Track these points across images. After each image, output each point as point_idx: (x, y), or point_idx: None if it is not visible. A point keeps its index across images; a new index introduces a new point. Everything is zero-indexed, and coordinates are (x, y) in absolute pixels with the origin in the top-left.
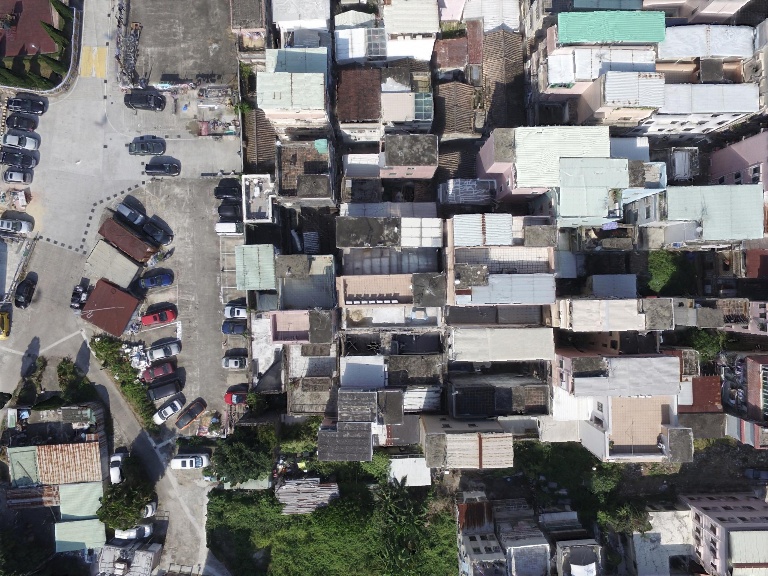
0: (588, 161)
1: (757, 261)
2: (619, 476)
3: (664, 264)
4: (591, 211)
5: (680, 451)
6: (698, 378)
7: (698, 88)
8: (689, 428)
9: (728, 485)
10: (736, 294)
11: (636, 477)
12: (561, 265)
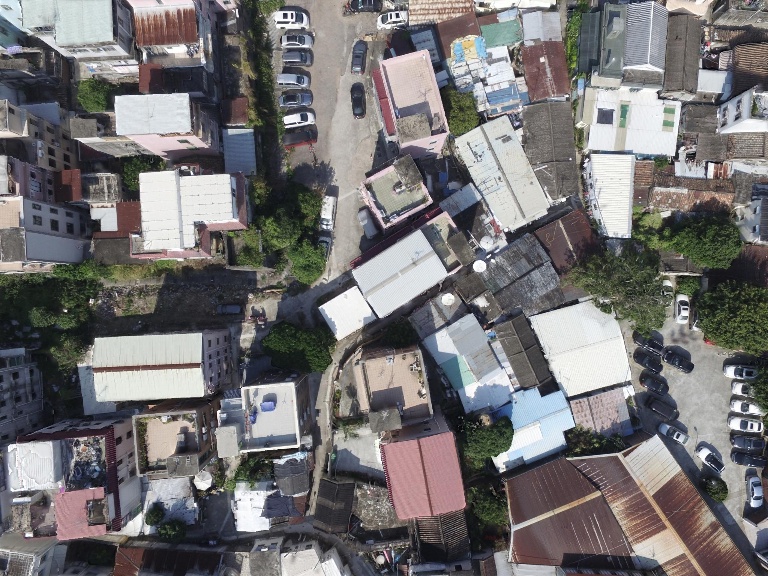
0: None
1: (147, 75)
2: (85, 316)
3: (88, 91)
4: None
5: (12, 250)
6: (122, 203)
7: None
8: (22, 227)
9: (203, 323)
10: None
11: (109, 318)
12: None
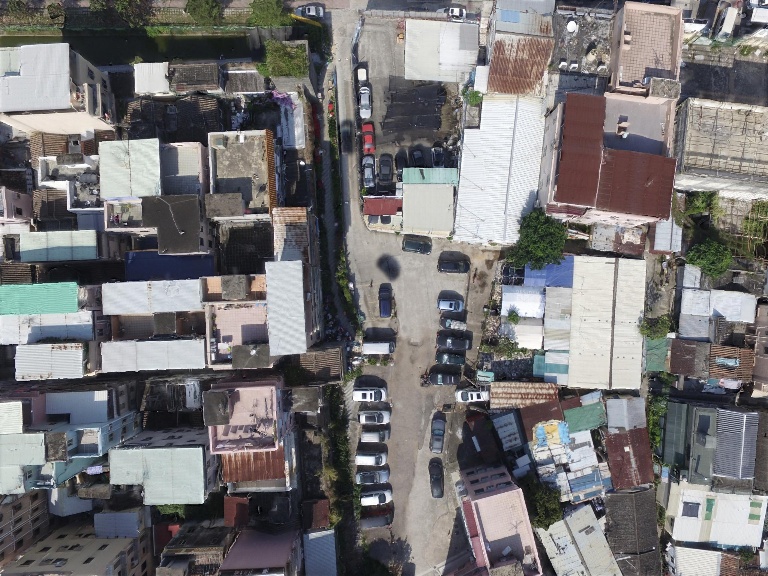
0: (2, 437)
1: (233, 510)
2: None
3: None
4: (6, 489)
5: None
6: None
7: (142, 346)
8: None
9: None
10: (255, 523)
11: None
12: (65, 503)
